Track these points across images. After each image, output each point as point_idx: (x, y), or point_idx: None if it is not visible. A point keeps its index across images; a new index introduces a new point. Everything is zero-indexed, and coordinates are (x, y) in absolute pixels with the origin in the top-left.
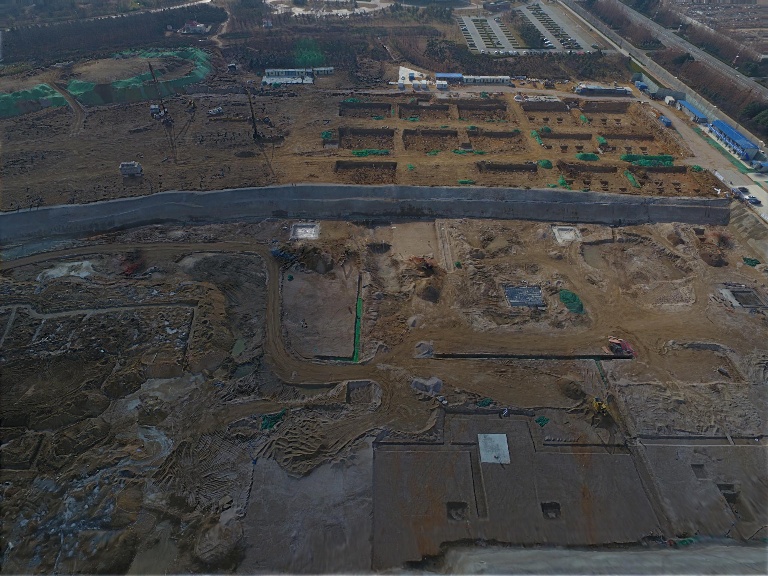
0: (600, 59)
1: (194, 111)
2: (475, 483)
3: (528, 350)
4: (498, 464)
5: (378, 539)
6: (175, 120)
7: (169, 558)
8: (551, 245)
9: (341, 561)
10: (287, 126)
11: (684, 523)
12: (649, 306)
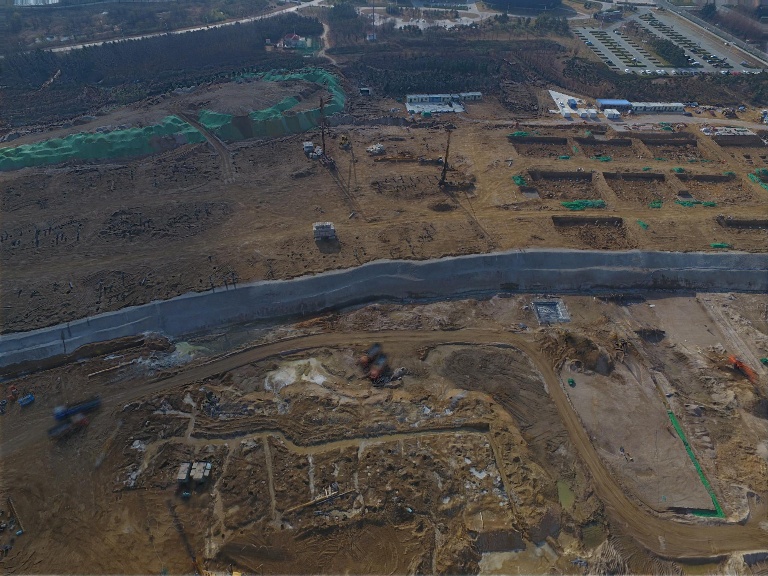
0: (765, 81)
1: (350, 148)
2: None
3: None
4: None
5: None
6: (335, 160)
7: None
8: None
9: None
10: (467, 168)
11: None
12: None
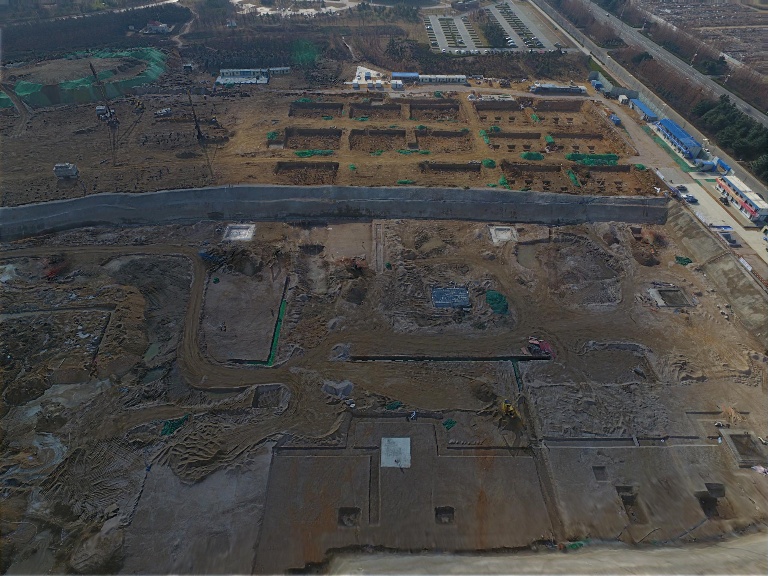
0: (560, 58)
1: (142, 112)
2: (371, 488)
3: (446, 352)
4: (398, 468)
5: (263, 546)
6: (121, 121)
7: (44, 569)
8: (485, 245)
9: (221, 570)
10: (234, 127)
11: (576, 526)
12: (575, 306)
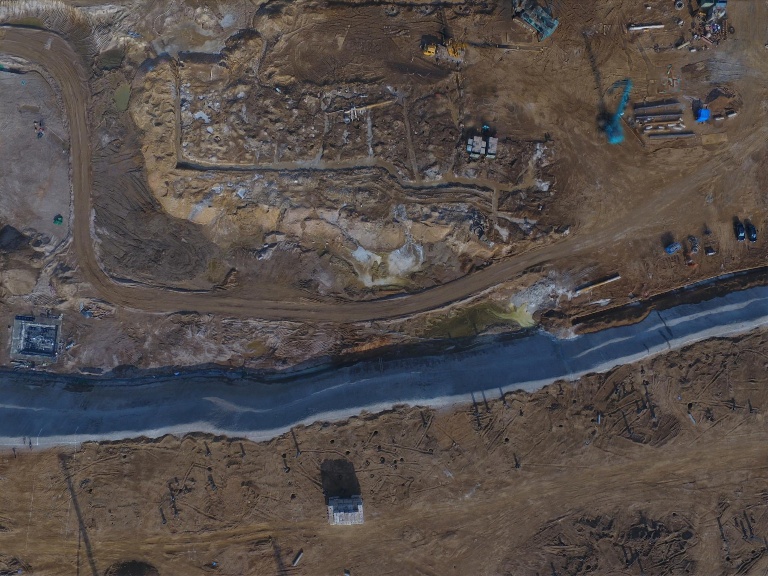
0: None
1: None
2: None
3: None
4: None
5: None
6: None
7: None
8: None
9: None
10: None
11: None
12: None
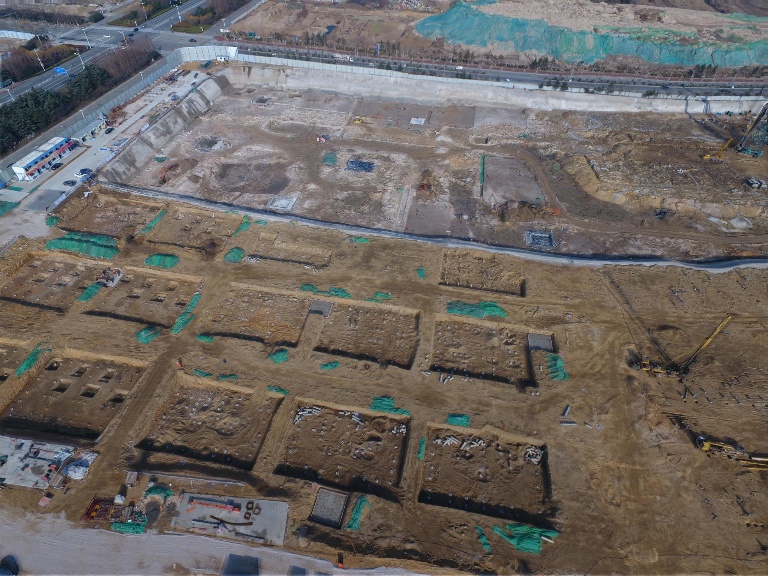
0: None
1: None
2: None
3: (379, 143)
4: None
5: None
6: None
7: None
8: (308, 194)
9: None
10: (645, 412)
11: None
12: (278, 151)
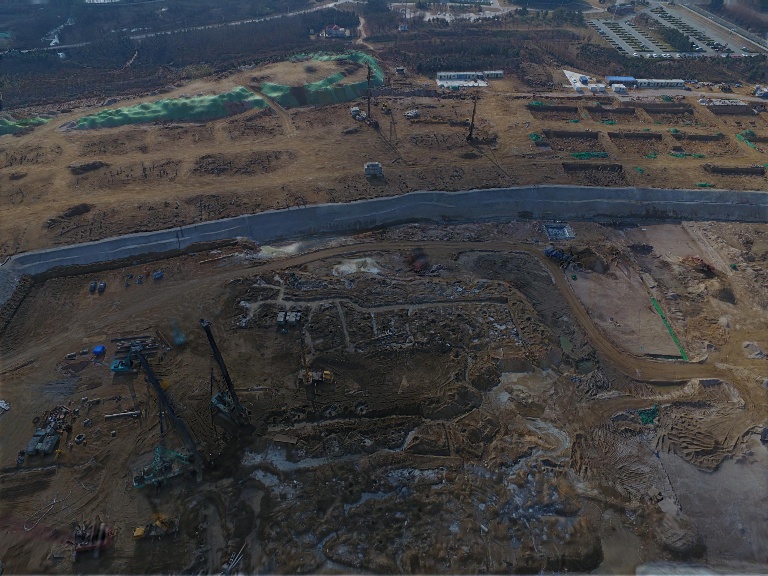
0: (761, 63)
1: (390, 113)
2: None
3: None
4: None
5: None
6: (378, 122)
7: (635, 545)
8: None
9: None
10: (491, 128)
11: None
12: None
